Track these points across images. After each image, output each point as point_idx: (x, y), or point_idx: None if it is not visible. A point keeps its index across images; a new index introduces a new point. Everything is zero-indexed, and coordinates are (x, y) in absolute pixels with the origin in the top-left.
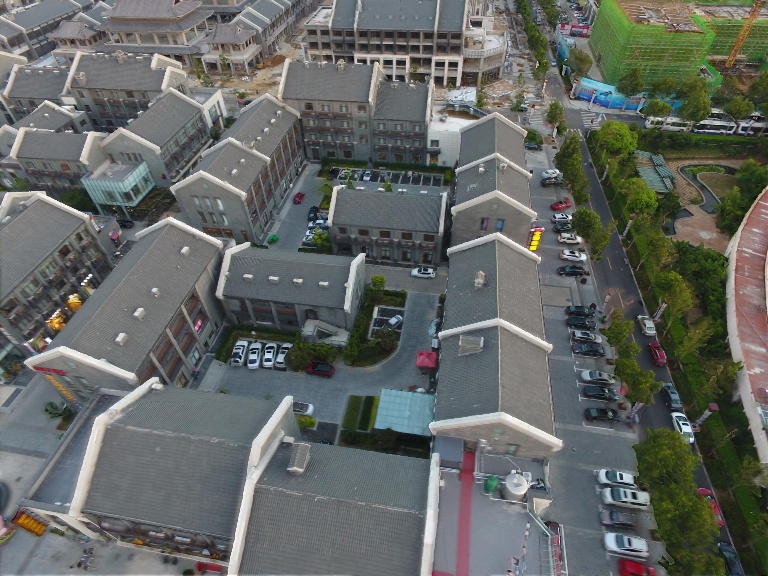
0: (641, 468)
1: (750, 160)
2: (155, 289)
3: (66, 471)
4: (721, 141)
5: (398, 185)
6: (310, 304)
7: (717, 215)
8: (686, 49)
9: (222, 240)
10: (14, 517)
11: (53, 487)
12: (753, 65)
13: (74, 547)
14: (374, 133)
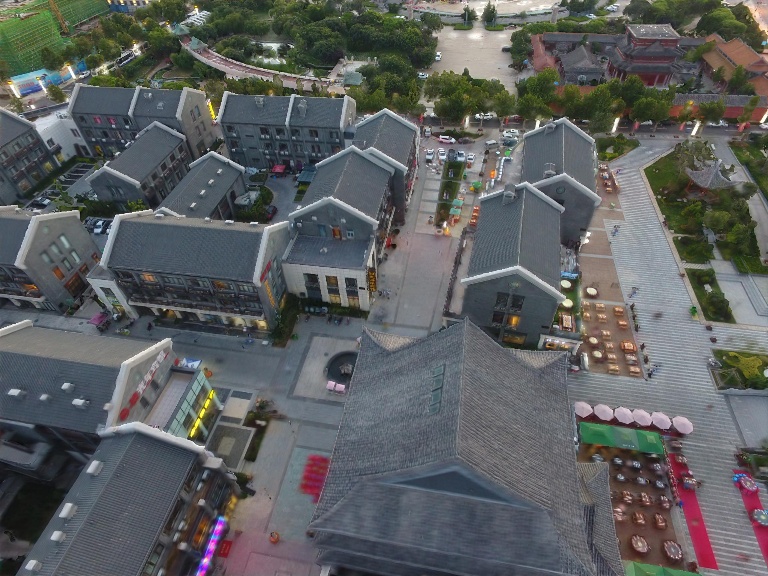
0: (358, 108)
1: (172, 54)
2: (207, 218)
3: (343, 263)
4: (140, 61)
5: (73, 186)
6: (231, 185)
7: (205, 79)
8: (43, 27)
9: None
10: (373, 267)
11: (353, 265)
12: (61, 33)
13: (377, 304)
14: (4, 166)
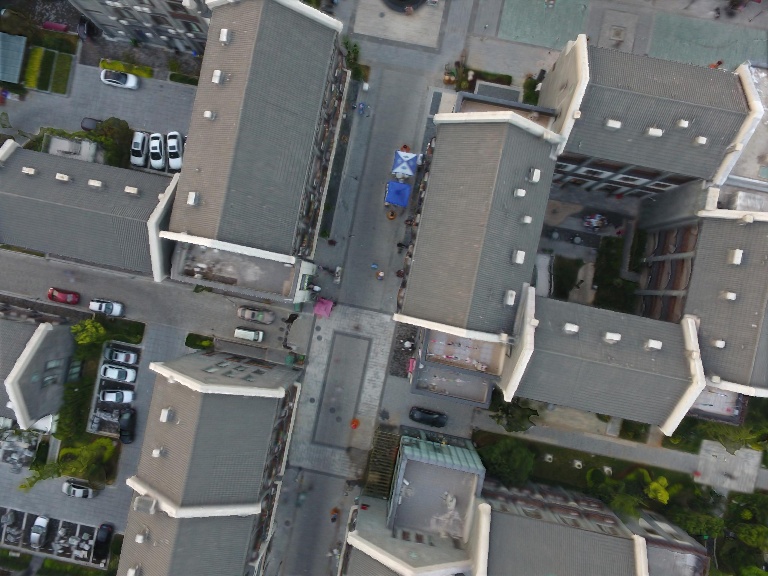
0: None
1: None
2: (206, 114)
3: None
4: None
5: None
6: None
7: None
8: None
9: (189, 277)
10: None
11: None
12: None
13: None
14: None
